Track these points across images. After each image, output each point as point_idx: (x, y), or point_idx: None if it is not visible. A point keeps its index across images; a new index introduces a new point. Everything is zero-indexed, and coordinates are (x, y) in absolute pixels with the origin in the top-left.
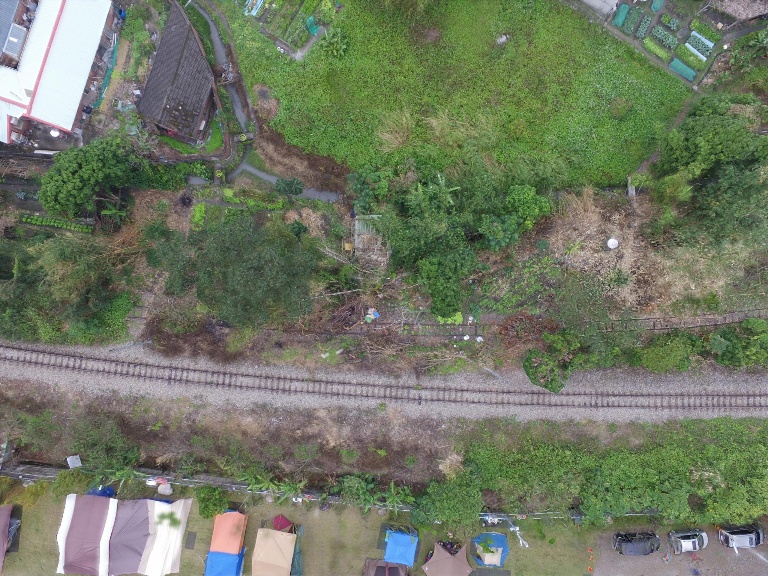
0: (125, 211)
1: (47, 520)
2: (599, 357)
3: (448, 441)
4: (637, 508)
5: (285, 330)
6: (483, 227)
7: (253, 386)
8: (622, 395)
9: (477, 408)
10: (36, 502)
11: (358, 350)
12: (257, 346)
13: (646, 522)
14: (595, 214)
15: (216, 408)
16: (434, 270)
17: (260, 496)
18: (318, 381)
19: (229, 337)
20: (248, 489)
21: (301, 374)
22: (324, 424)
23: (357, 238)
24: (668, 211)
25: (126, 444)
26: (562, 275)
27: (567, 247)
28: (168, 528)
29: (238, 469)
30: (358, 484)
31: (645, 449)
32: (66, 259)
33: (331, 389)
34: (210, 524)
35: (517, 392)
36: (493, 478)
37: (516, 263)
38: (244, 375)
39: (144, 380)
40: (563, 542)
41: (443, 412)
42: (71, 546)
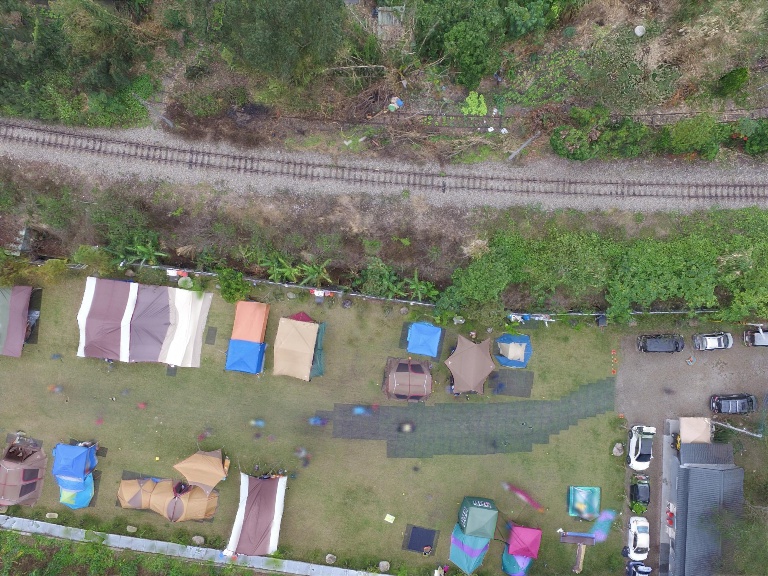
0: (144, 6)
1: (66, 312)
2: (627, 132)
3: (472, 230)
4: (663, 295)
5: (307, 118)
6: (509, 6)
7: (275, 171)
8: (649, 184)
9: (502, 196)
10: (55, 294)
11: (381, 136)
12: (279, 133)
13: (670, 325)
14: (621, 8)
15: (237, 194)
16: (462, 30)
17: (281, 292)
18: (341, 167)
19: (250, 124)
20: (270, 279)
21: (324, 160)
22: (347, 212)
23: (380, 30)
24: (696, 1)
25: (147, 220)
26: (588, 68)
27: (593, 40)
28: (189, 320)
29: (260, 250)
30: (382, 263)
31: (671, 238)
32: (88, 10)
33: (354, 176)
34: (231, 320)
35: (542, 180)
36: (518, 266)
37: (543, 43)
38: (266, 160)
39: (165, 163)
40: (586, 344)
41: (467, 200)
42: (92, 326)
